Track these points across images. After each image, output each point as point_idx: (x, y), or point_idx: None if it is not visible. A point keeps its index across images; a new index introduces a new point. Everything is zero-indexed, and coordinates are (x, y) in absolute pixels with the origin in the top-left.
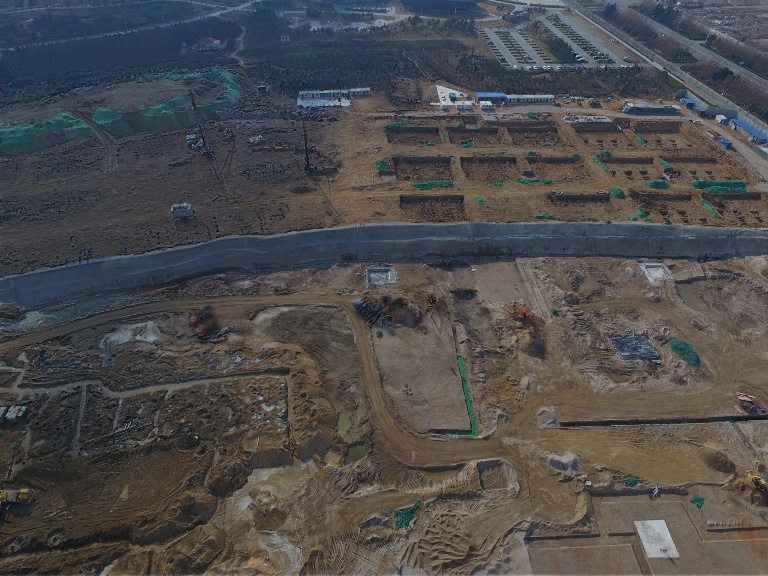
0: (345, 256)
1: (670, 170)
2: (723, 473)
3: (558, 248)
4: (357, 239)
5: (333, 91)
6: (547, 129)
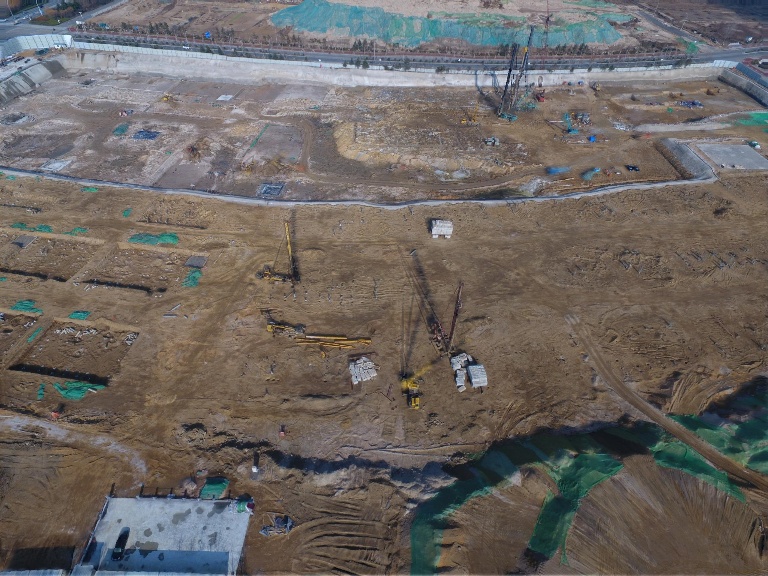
0: None
1: None
2: None
3: None
4: None
5: None
6: None
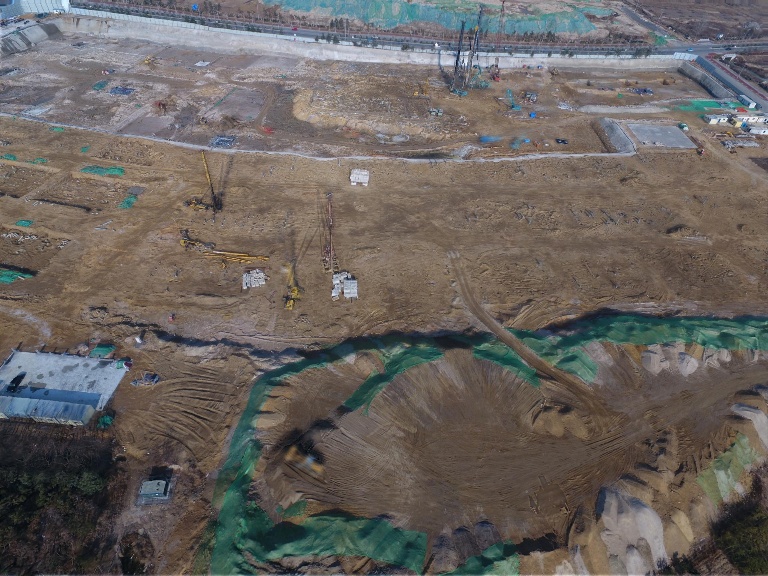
0: None
1: None
2: None
3: None
4: None
5: (3, 401)
6: None
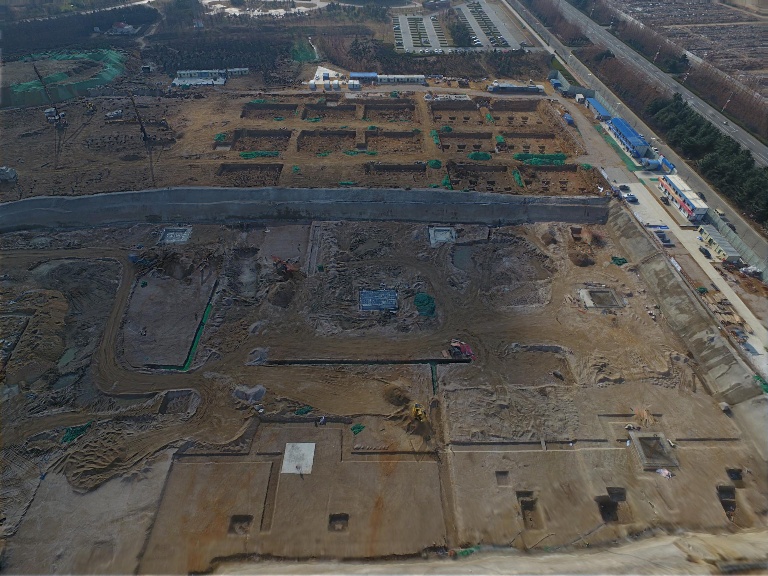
0: (149, 217)
1: (502, 144)
2: (395, 406)
3: (355, 212)
4: (162, 201)
5: (211, 71)
6: (405, 107)
